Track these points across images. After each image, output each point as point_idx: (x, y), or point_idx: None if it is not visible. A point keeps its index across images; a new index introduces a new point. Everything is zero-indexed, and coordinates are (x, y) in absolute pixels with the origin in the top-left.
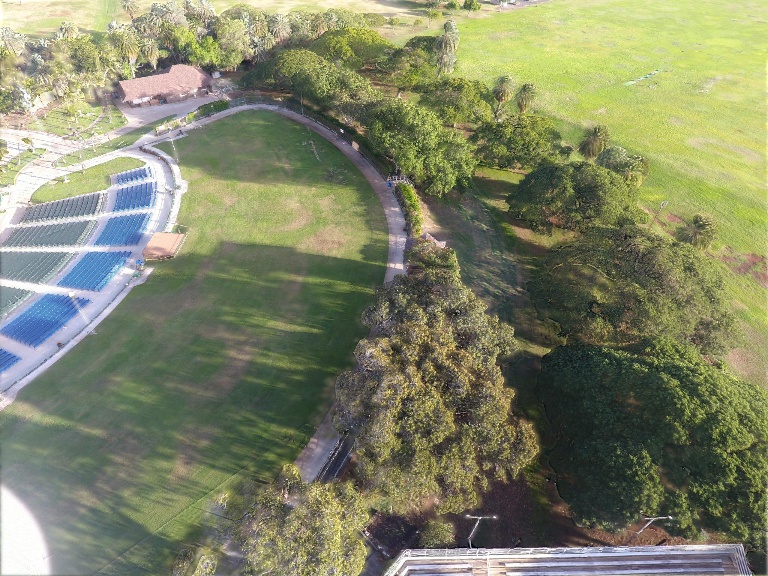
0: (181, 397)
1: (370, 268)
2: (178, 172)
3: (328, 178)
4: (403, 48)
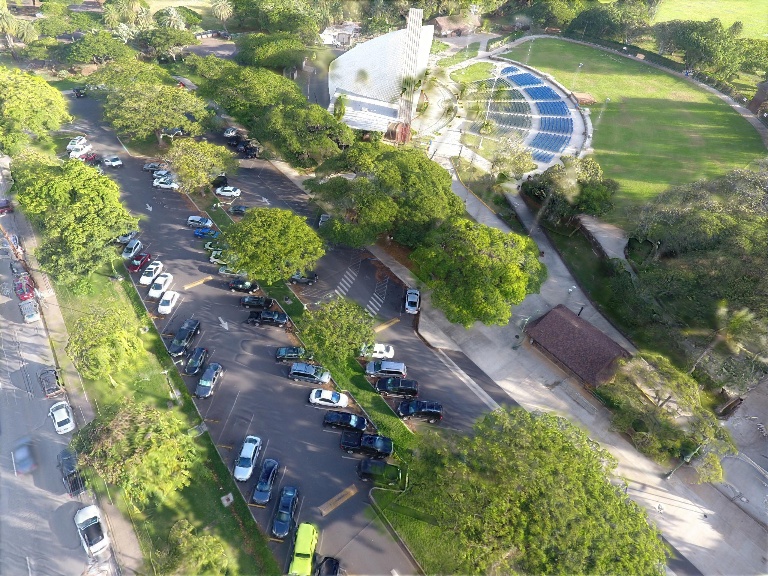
0: (684, 146)
1: (722, 106)
2: (535, 69)
3: (641, 72)
4: (626, 1)
